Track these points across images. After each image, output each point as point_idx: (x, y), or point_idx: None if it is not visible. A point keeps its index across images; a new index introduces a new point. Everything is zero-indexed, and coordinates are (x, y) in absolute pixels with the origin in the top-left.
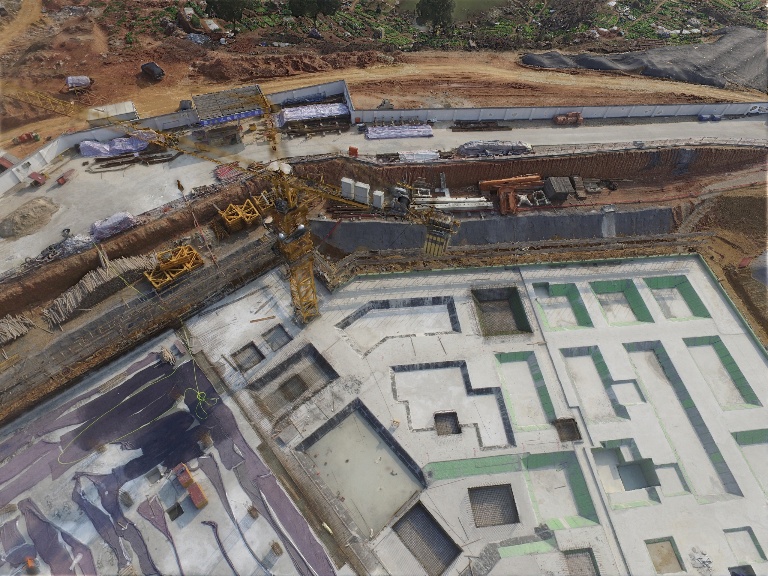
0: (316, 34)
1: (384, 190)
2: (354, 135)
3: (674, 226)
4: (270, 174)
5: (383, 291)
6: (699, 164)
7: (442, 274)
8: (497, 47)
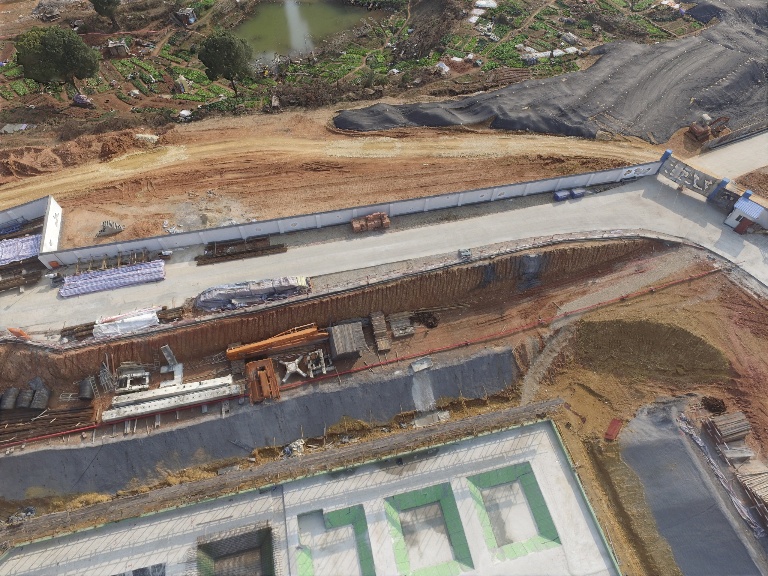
0: (81, 101)
1: (76, 384)
2: (42, 292)
3: (518, 374)
4: None
5: (53, 572)
6: (552, 271)
7: (158, 518)
8: (308, 103)
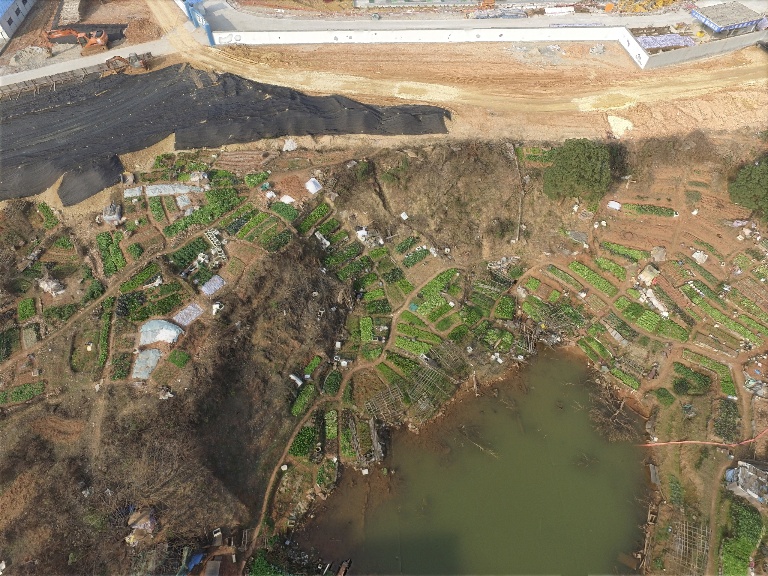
0: None
1: None
2: None
3: None
4: (660, 8)
5: (556, 1)
6: None
7: None
8: None
